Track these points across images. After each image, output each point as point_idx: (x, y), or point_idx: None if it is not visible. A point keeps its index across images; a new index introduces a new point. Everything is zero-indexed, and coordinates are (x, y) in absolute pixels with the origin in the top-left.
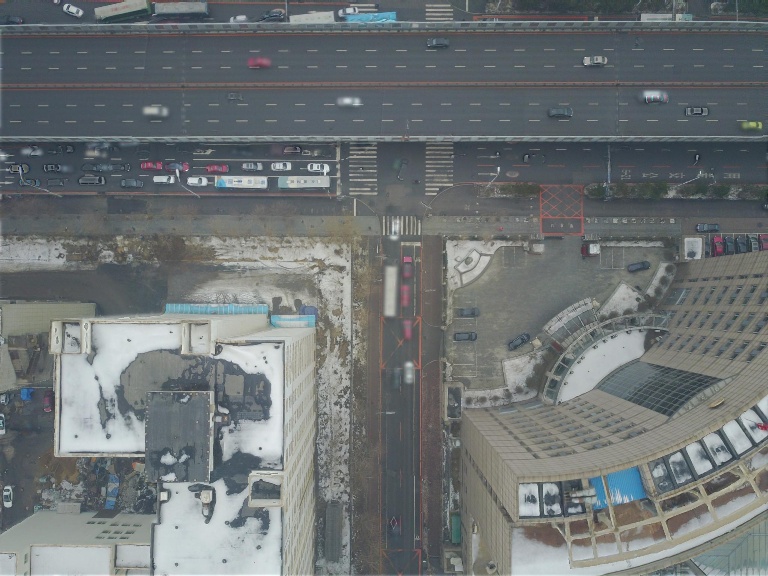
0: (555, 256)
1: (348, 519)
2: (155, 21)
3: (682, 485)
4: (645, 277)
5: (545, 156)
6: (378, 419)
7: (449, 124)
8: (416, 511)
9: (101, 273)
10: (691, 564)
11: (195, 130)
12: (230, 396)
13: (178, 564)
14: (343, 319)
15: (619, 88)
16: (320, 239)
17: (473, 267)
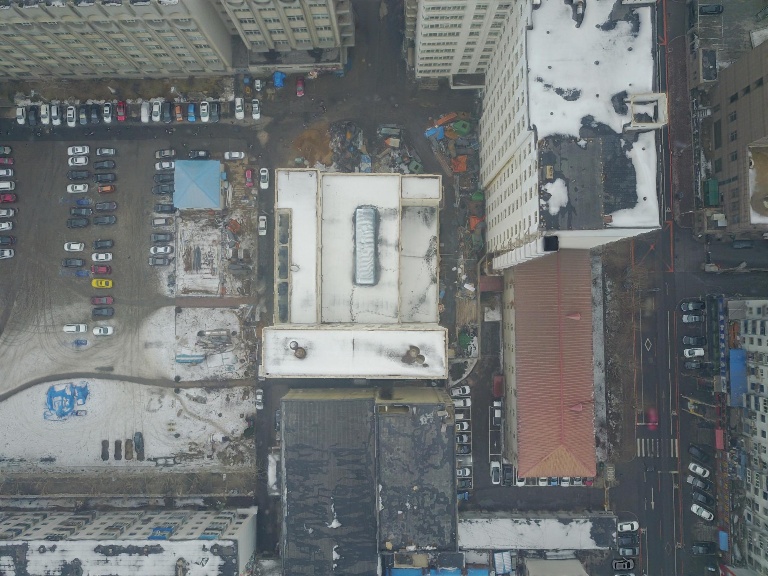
0: None
1: None
2: None
3: None
4: None
5: None
6: None
7: None
8: (666, 183)
9: None
10: None
11: None
12: None
13: (551, 67)
14: None
15: None
16: None
17: None
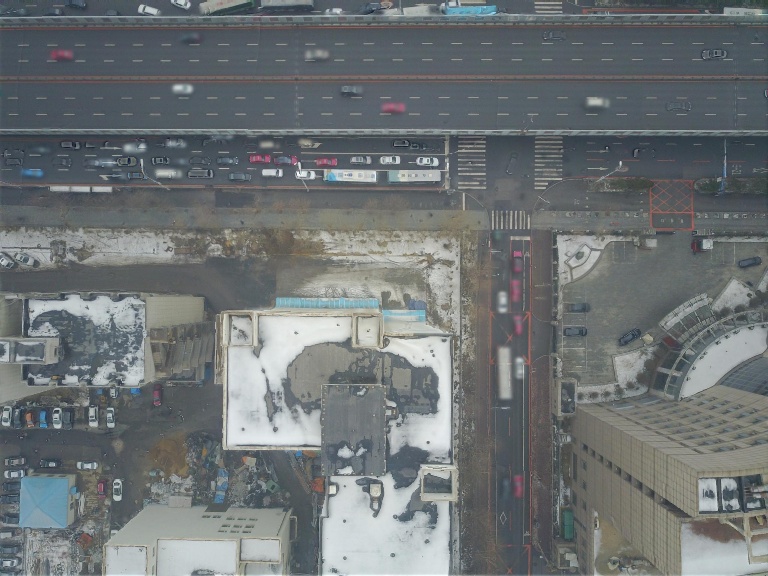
0: (665, 251)
1: (458, 514)
2: (267, 13)
3: None
4: (756, 273)
5: (655, 151)
6: (487, 414)
7: (565, 118)
8: (526, 506)
9: (209, 267)
10: None
11: (309, 123)
12: (397, 389)
13: (346, 558)
14: (452, 314)
15: (738, 82)
16: (429, 233)
17: (584, 262)
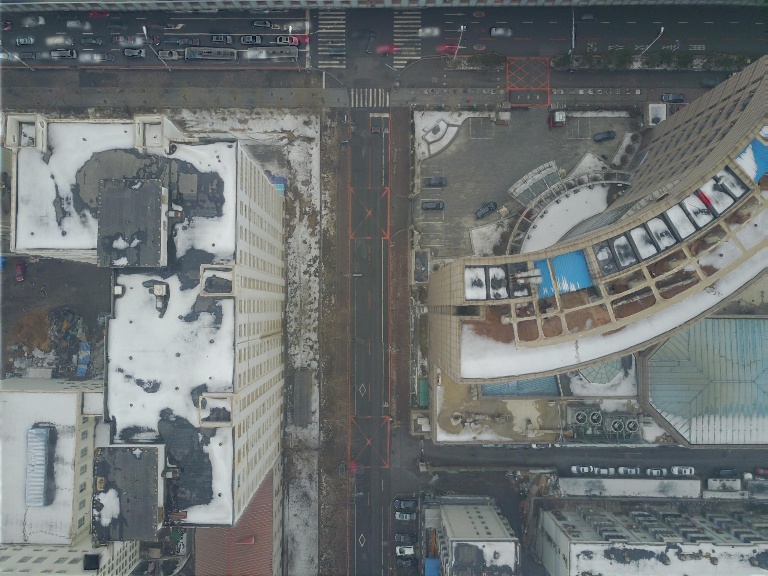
0: (522, 127)
1: (317, 386)
2: None
3: (626, 267)
4: (611, 147)
5: (512, 29)
6: (347, 288)
7: None
8: (385, 378)
9: None
10: (653, 410)
11: None
12: (184, 194)
13: (132, 357)
14: (312, 190)
15: None
16: (289, 111)
17: (440, 137)
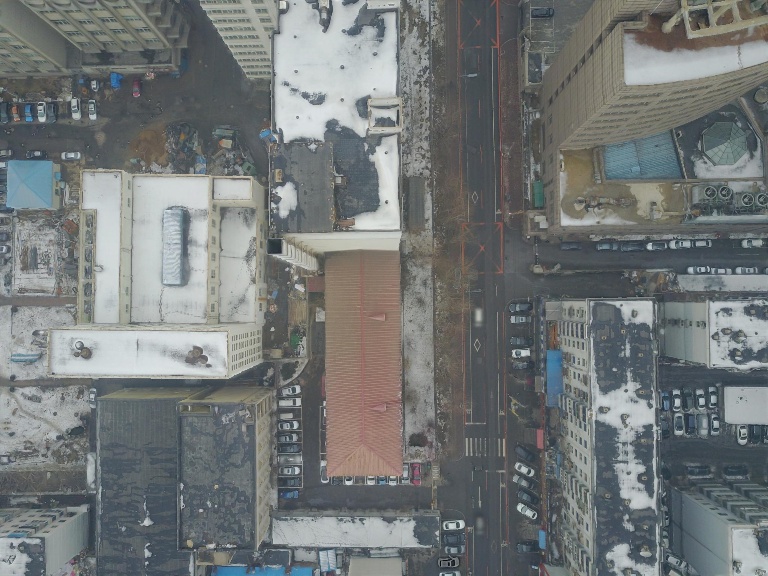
0: None
1: (430, 194)
2: None
3: None
4: None
5: None
6: (457, 99)
7: None
8: (497, 185)
9: None
10: None
11: None
12: None
13: (297, 71)
14: (421, 1)
15: None
16: None
17: None
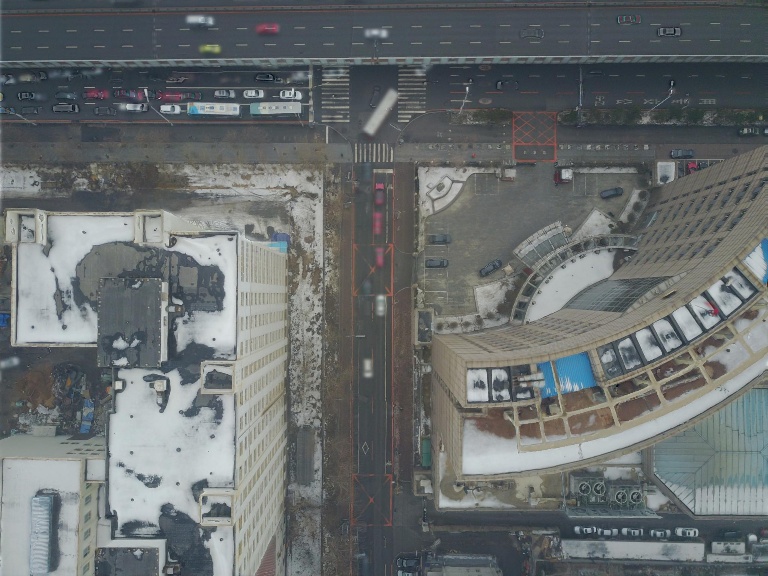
0: (528, 183)
1: (320, 444)
2: None
3: (631, 370)
4: (618, 204)
5: (518, 83)
6: (350, 346)
7: (419, 47)
8: (388, 436)
9: (75, 200)
10: (657, 481)
11: (166, 55)
12: (184, 287)
13: (133, 452)
14: (315, 246)
15: (591, 9)
16: (292, 166)
17: (445, 194)
